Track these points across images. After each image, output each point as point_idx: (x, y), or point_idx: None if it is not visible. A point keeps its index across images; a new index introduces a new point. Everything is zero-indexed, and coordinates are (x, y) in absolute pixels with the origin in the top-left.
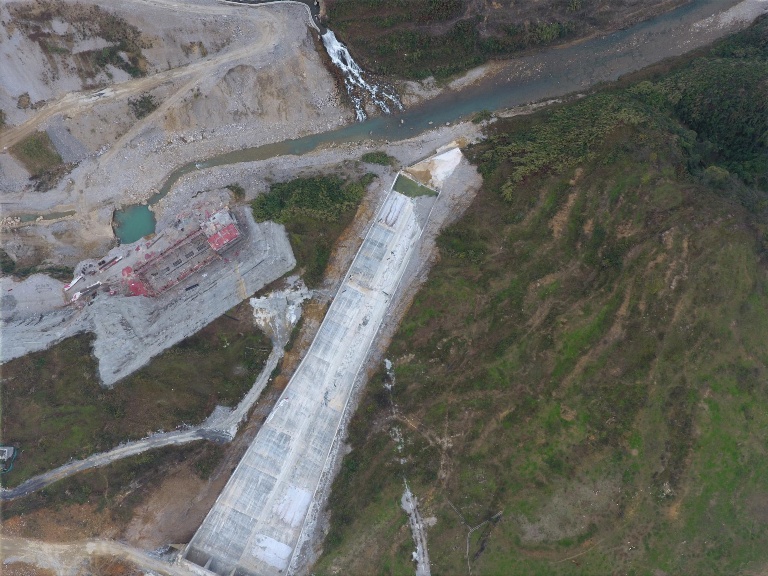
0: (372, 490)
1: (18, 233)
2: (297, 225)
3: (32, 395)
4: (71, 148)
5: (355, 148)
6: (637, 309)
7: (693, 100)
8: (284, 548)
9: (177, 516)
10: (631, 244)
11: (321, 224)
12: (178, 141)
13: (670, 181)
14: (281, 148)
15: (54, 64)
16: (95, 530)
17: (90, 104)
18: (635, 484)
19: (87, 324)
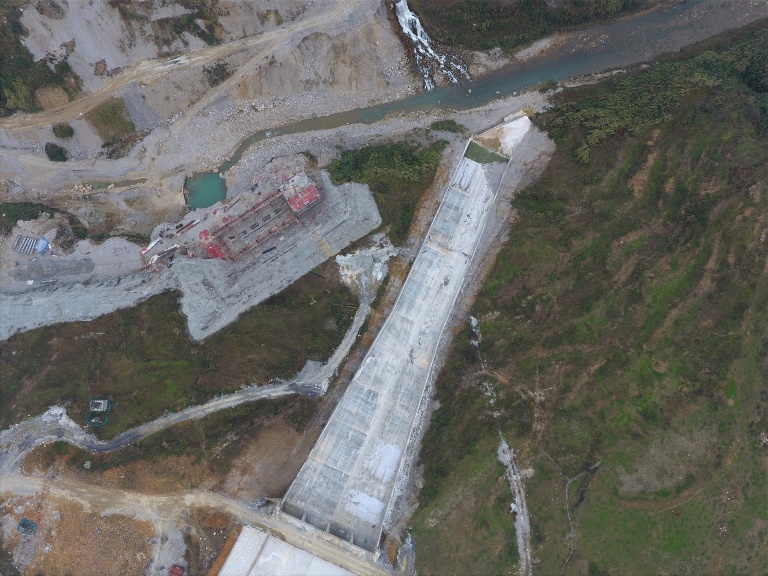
0: (467, 443)
1: (90, 200)
2: (380, 184)
3: (123, 350)
4: (145, 115)
5: (423, 117)
6: (726, 262)
7: (761, 66)
8: (377, 503)
9: (275, 468)
10: (716, 199)
11: (404, 184)
12: (249, 109)
13: (751, 139)
14: (350, 117)
15: (132, 31)
16: (193, 482)
17: (165, 71)
18: (731, 434)
19: (172, 282)
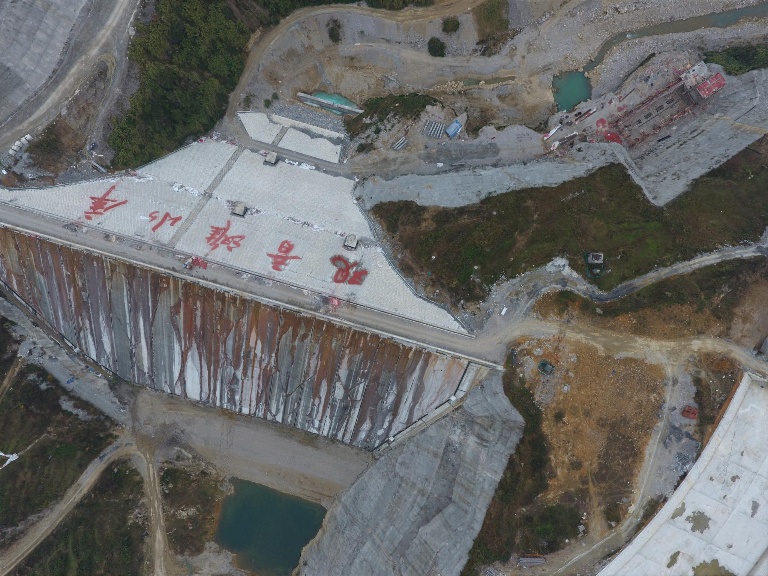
0: None
1: (465, 95)
2: None
3: (595, 213)
4: (521, 13)
5: None
6: None
7: None
8: None
9: None
10: None
11: None
12: (613, 11)
13: None
14: (705, 21)
15: None
16: (699, 328)
17: None
18: None
19: (610, 157)
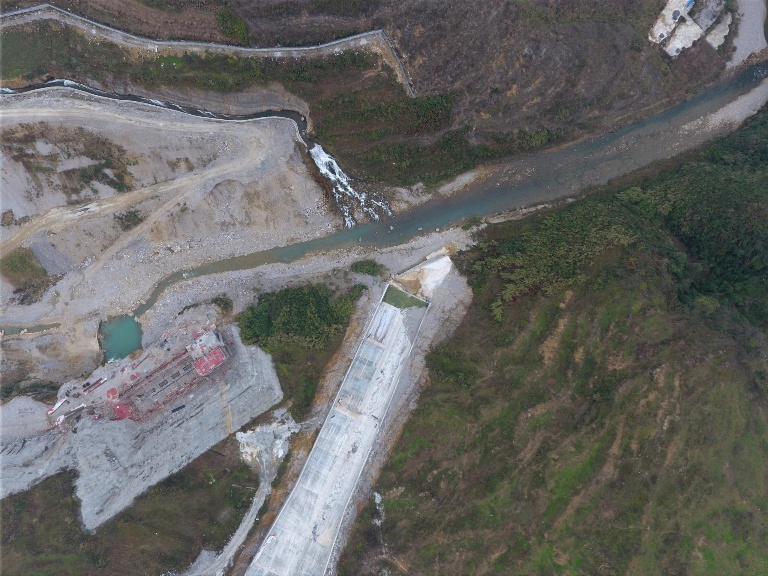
0: None
1: (2, 347)
2: (284, 354)
3: (12, 543)
4: (56, 262)
5: (344, 255)
6: (629, 449)
7: (683, 214)
8: None
9: None
10: (622, 379)
11: (309, 352)
12: (165, 251)
13: (661, 311)
14: (269, 256)
15: (38, 182)
16: None
17: (75, 219)
18: None
19: (70, 459)
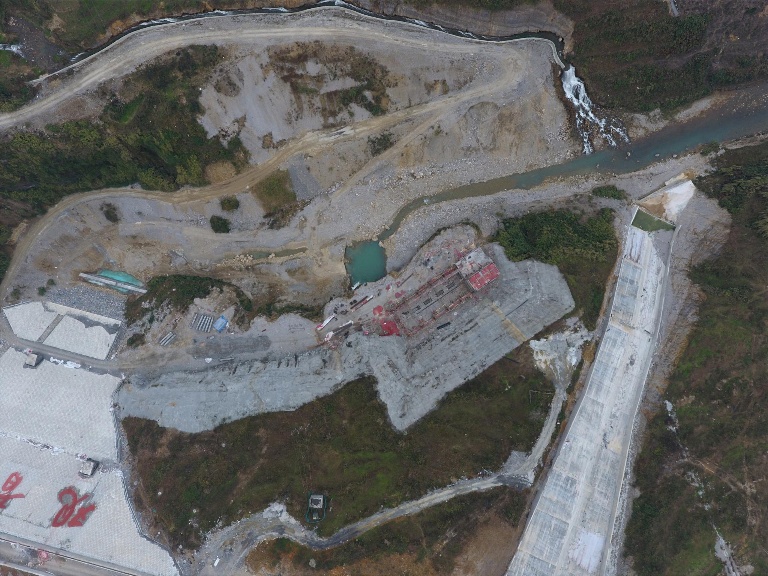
0: (680, 537)
1: (252, 271)
2: (569, 266)
3: (330, 441)
4: (307, 186)
5: (582, 181)
6: None
7: None
8: None
9: (496, 565)
10: None
11: (592, 264)
12: (408, 177)
13: None
14: (508, 182)
15: (300, 104)
16: None
17: (330, 143)
18: None
19: (364, 367)
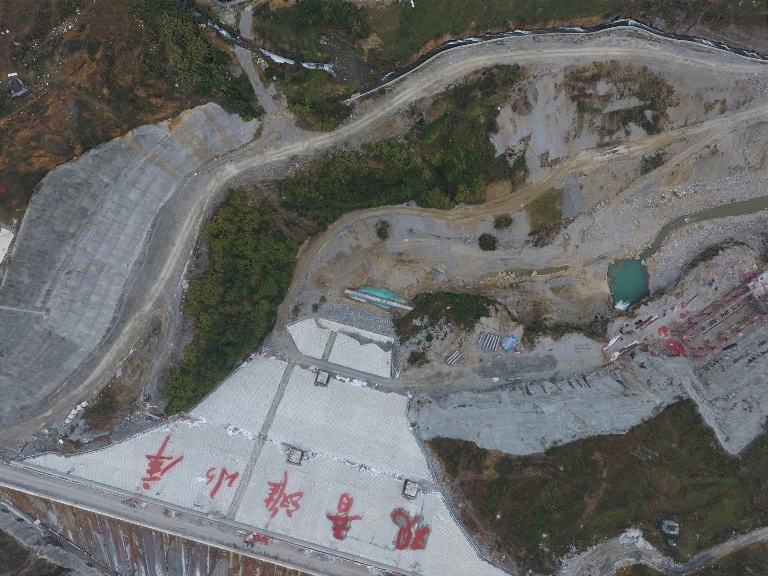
0: None
1: (517, 288)
2: None
3: (666, 466)
4: (575, 204)
5: None
6: None
7: None
8: None
9: None
10: None
11: None
12: (671, 195)
13: None
14: None
15: (581, 123)
16: None
17: (605, 161)
18: None
19: (678, 389)
